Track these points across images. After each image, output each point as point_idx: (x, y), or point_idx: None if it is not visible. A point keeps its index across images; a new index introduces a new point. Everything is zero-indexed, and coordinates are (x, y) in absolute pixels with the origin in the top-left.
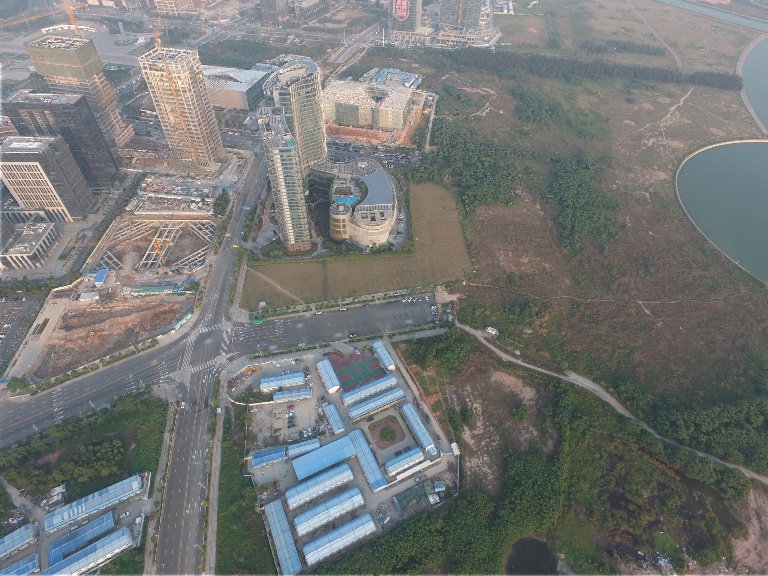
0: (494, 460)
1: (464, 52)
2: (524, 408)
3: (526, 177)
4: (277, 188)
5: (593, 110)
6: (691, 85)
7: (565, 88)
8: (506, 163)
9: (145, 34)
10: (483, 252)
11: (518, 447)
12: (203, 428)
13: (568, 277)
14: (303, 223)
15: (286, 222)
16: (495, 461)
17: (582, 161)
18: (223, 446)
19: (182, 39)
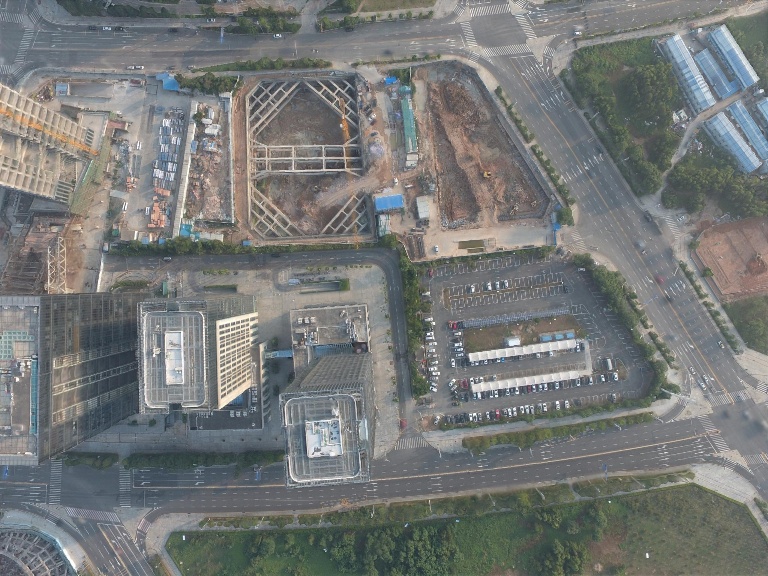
0: None
1: None
2: None
3: None
4: None
5: None
6: None
7: None
8: None
9: None
10: None
11: None
12: (604, 5)
13: None
14: None
15: None
16: None
17: None
18: None
19: None
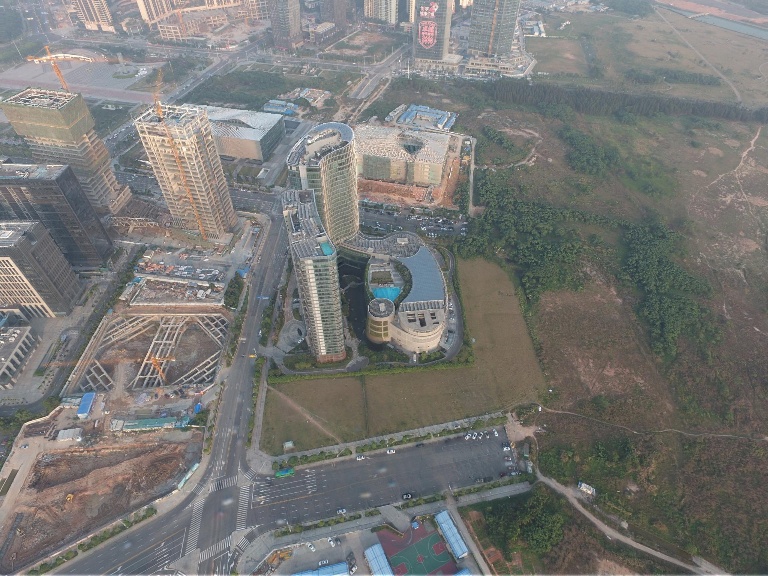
0: None
1: (500, 85)
2: None
3: (593, 249)
4: (308, 300)
5: (654, 157)
6: (758, 123)
7: (618, 128)
8: (566, 230)
9: (147, 64)
10: (557, 361)
11: None
12: None
13: (669, 399)
14: (338, 334)
15: (317, 334)
16: None
17: (656, 228)
18: None
19: (187, 70)
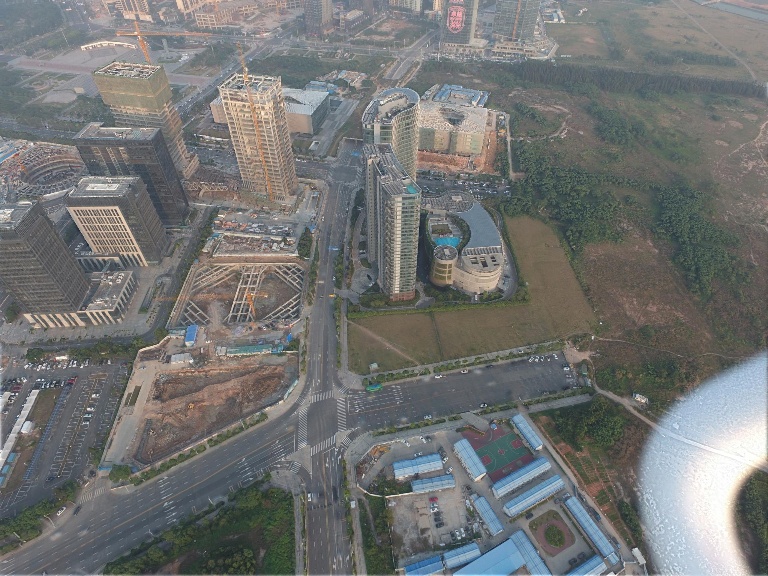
0: (687, 571)
1: (528, 66)
2: (707, 501)
3: (628, 208)
4: (392, 237)
5: (678, 129)
6: None
7: (641, 104)
8: (602, 192)
9: (188, 50)
10: (604, 299)
11: (711, 553)
12: (338, 528)
13: (707, 329)
14: (412, 272)
15: (394, 271)
16: (689, 572)
17: (685, 189)
18: (368, 554)
19: (227, 55)
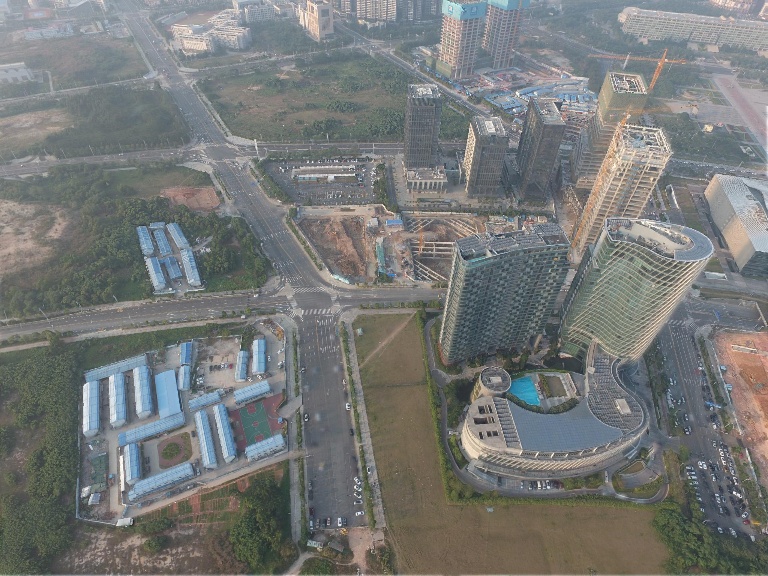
0: (92, 571)
1: None
2: None
3: None
4: None
5: None
6: None
7: None
8: None
9: None
10: None
11: None
12: None
13: None
14: (448, 336)
15: None
16: (91, 572)
17: None
18: None
19: None
